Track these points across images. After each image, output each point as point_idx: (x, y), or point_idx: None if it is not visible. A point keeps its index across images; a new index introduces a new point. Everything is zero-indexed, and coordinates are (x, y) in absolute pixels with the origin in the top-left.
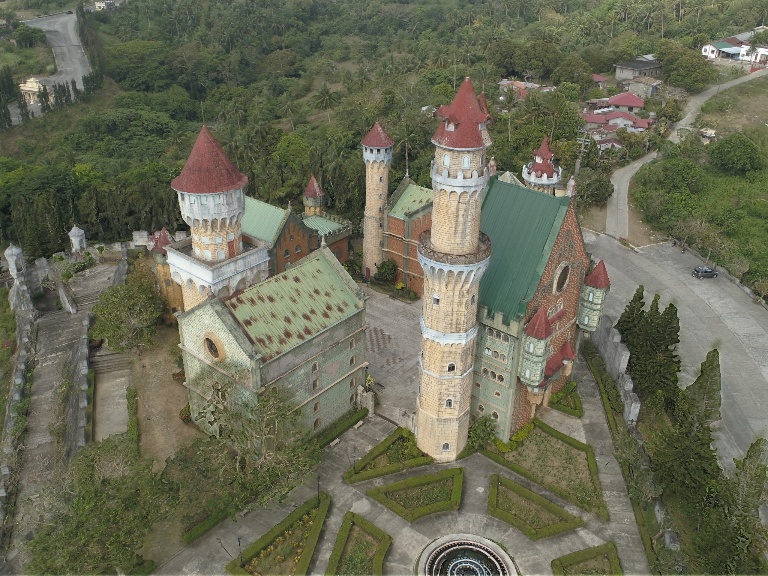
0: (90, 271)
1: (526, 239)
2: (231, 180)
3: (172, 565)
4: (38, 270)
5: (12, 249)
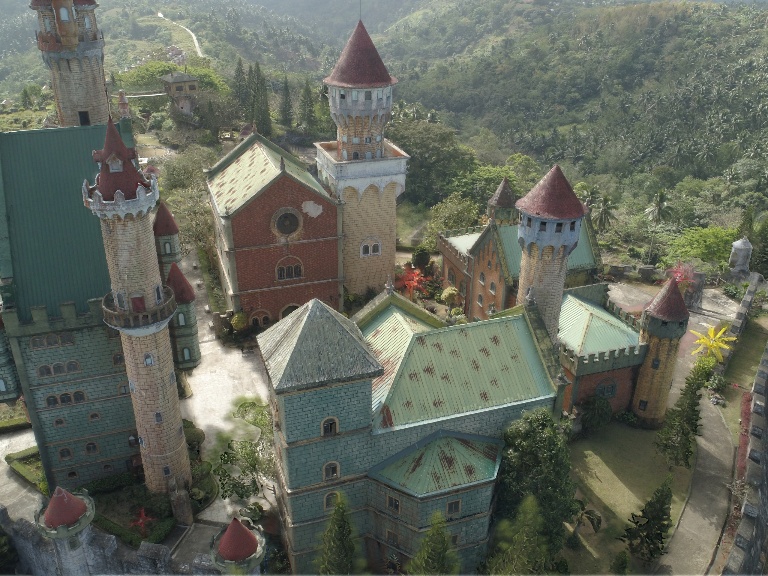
0: (728, 302)
1: None
2: (334, 75)
3: None
4: None
5: (740, 241)
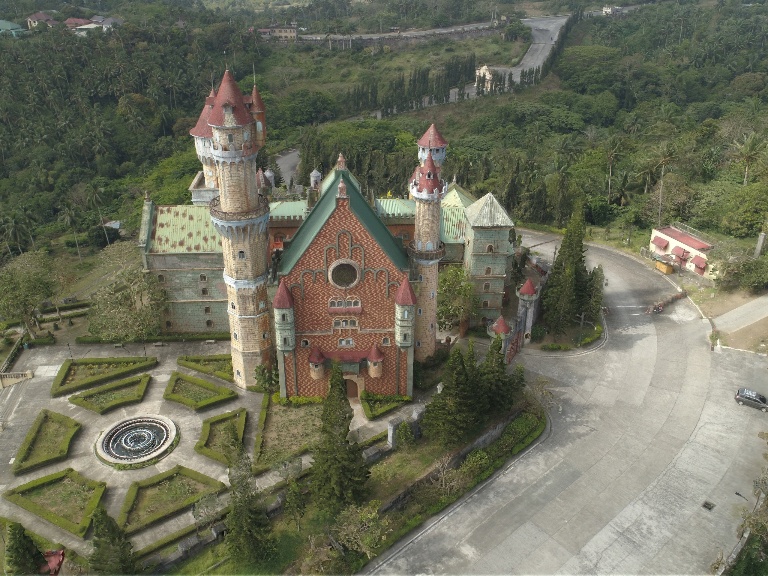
0: None
1: None
2: None
3: (60, 347)
4: None
5: (267, 172)
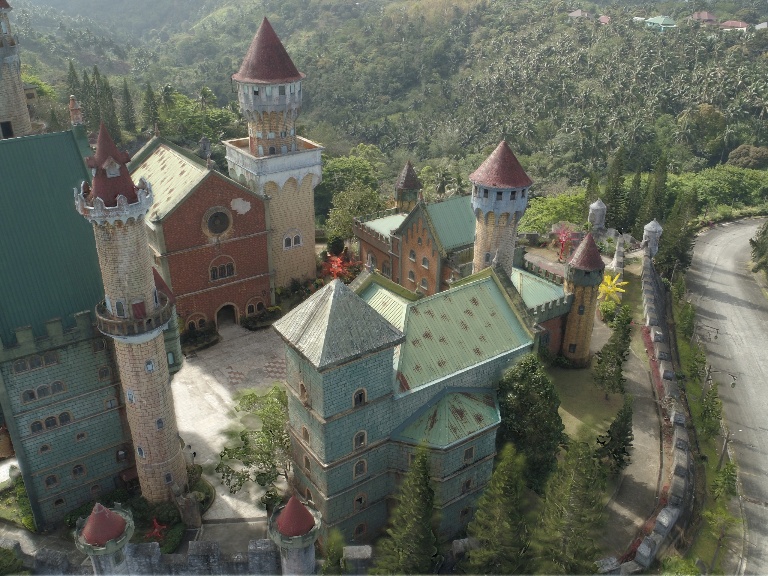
0: None
1: None
2: None
3: None
4: (606, 238)
5: None
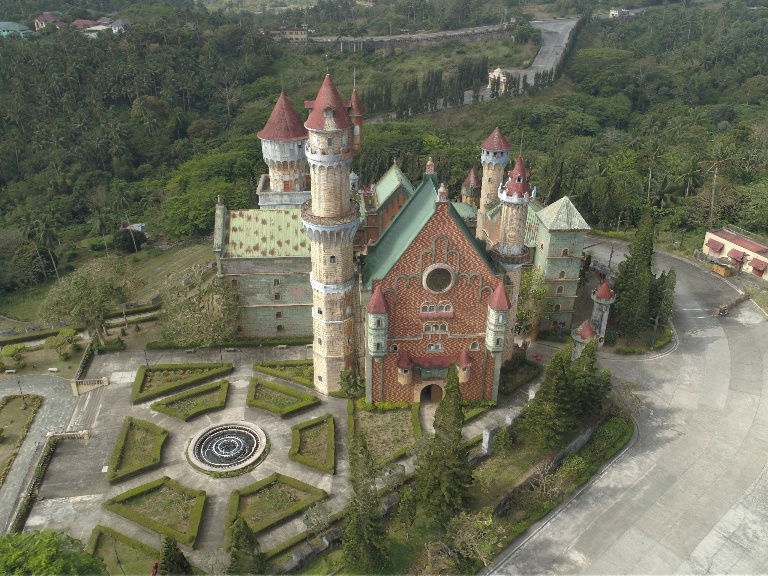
0: None
1: (410, 231)
2: (287, 135)
3: (131, 353)
4: None
5: None
